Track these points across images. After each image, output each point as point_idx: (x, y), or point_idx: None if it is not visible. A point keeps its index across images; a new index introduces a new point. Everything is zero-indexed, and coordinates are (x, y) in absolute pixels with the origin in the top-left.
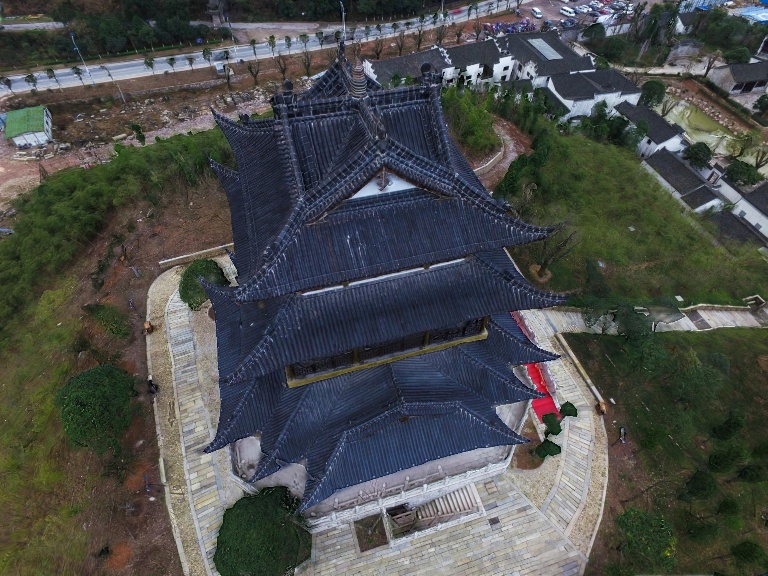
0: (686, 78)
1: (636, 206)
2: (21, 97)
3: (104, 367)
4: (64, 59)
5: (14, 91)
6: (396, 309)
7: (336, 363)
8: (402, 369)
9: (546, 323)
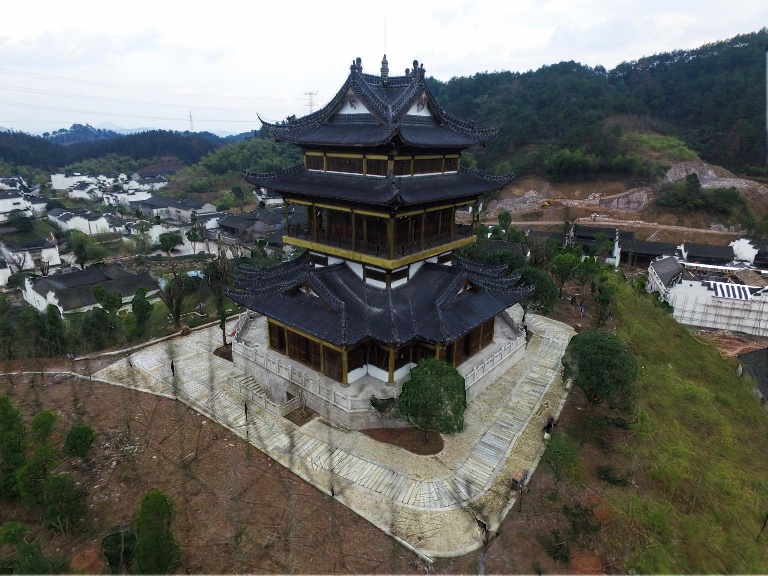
0: None
1: None
2: None
3: (583, 364)
4: None
5: None
6: None
7: None
8: None
9: None
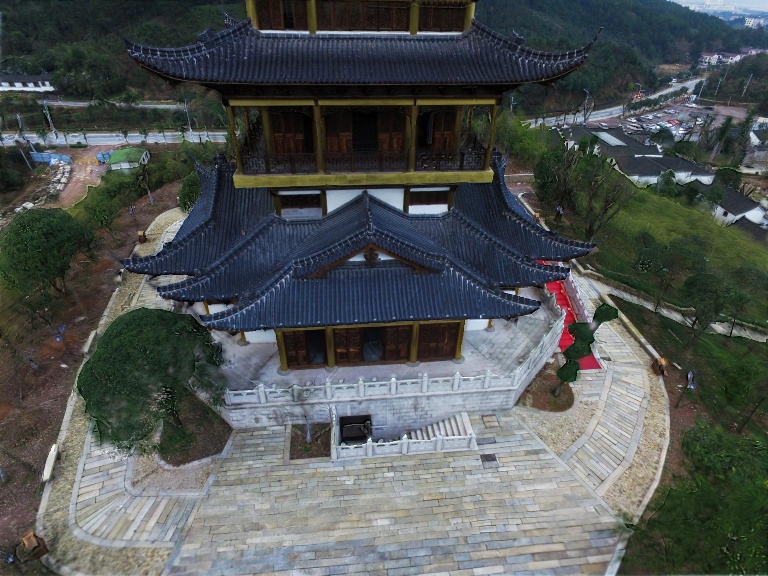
0: (766, 177)
1: (709, 234)
2: (132, 146)
3: None
4: (176, 126)
5: (128, 141)
6: (367, 61)
7: (296, 164)
8: (383, 217)
9: (589, 287)
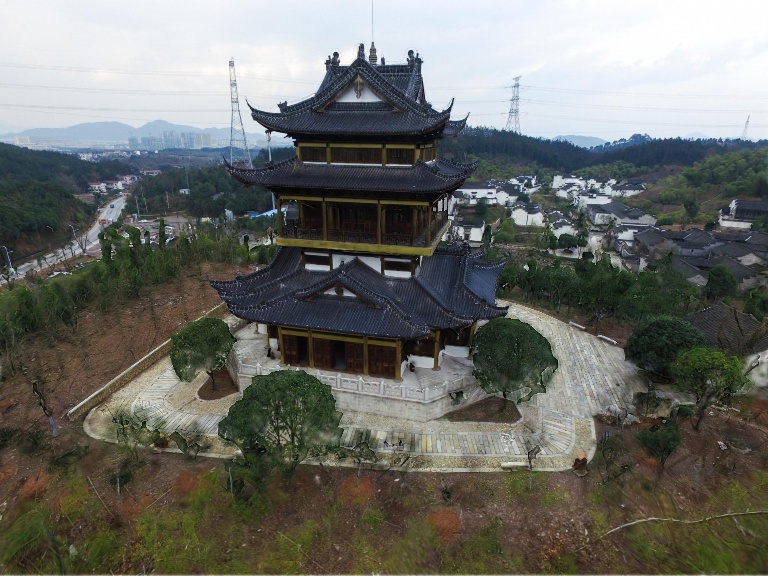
0: None
1: None
2: None
3: None
4: None
5: None
6: None
7: (433, 235)
8: None
9: None
